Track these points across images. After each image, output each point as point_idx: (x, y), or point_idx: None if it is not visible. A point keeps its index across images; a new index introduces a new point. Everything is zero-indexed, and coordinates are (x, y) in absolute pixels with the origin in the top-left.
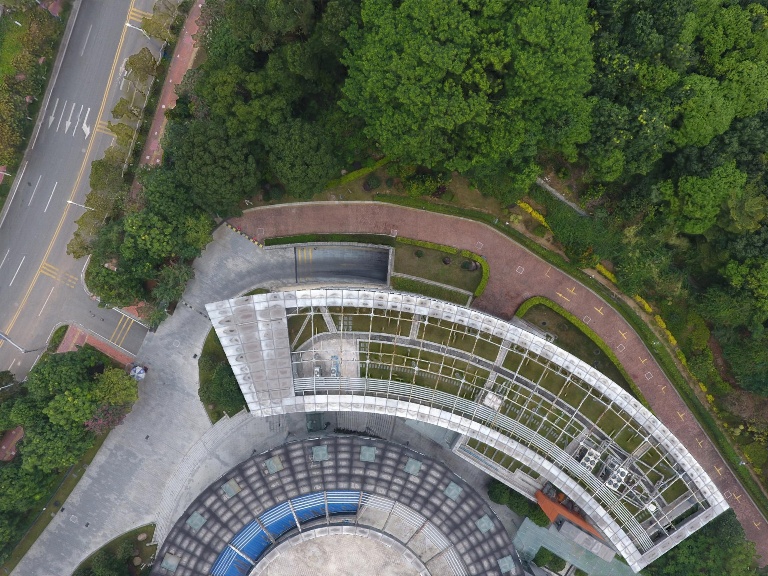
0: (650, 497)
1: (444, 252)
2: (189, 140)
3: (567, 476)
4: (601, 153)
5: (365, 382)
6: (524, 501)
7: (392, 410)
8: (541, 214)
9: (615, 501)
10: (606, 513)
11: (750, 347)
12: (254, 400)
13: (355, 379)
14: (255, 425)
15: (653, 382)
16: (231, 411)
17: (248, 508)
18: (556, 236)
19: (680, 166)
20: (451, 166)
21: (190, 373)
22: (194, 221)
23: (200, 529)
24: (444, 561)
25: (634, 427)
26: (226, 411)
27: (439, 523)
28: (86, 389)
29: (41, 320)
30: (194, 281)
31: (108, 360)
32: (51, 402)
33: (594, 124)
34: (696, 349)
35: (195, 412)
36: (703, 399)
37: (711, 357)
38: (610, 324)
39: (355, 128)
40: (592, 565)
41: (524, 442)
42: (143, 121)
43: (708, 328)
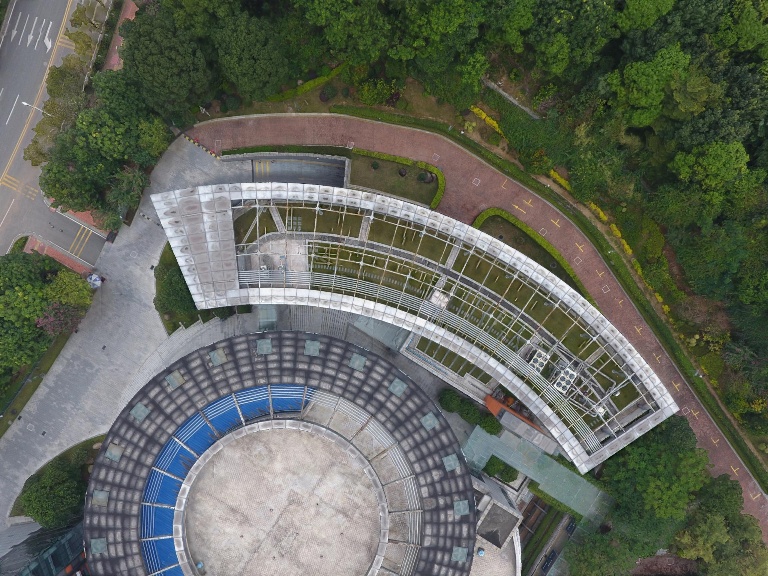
0: (598, 398)
1: (400, 164)
2: (136, 30)
3: (513, 375)
4: (543, 37)
5: (310, 276)
6: (475, 408)
7: (337, 304)
8: (495, 120)
9: (562, 401)
10: (553, 413)
11: (701, 245)
12: (198, 292)
13: (300, 273)
14: (210, 336)
15: (610, 296)
16: (187, 322)
17: (192, 400)
18: (509, 141)
19: (626, 54)
20: (394, 54)
21: (147, 284)
22: (147, 124)
23: (144, 420)
24: (391, 463)
25: (583, 328)
26: (182, 322)
27: (384, 420)
28: (37, 287)
29: (2, 231)
30: (152, 192)
31: (66, 270)
32: (1, 296)
33: (535, 5)
34: (651, 257)
35: (151, 323)
36: (659, 311)
37: (666, 265)
38: (567, 237)
39: (310, 35)
40: (544, 475)
41: (470, 339)
42: (104, 35)
43: (662, 234)
